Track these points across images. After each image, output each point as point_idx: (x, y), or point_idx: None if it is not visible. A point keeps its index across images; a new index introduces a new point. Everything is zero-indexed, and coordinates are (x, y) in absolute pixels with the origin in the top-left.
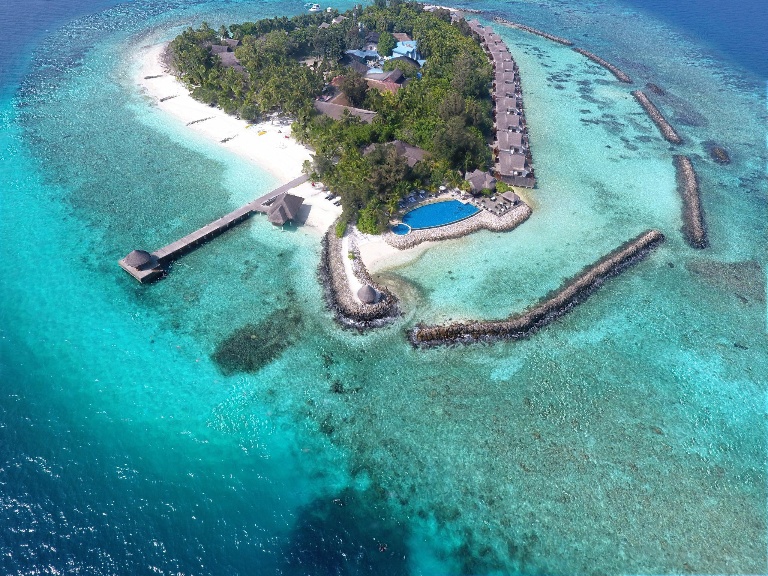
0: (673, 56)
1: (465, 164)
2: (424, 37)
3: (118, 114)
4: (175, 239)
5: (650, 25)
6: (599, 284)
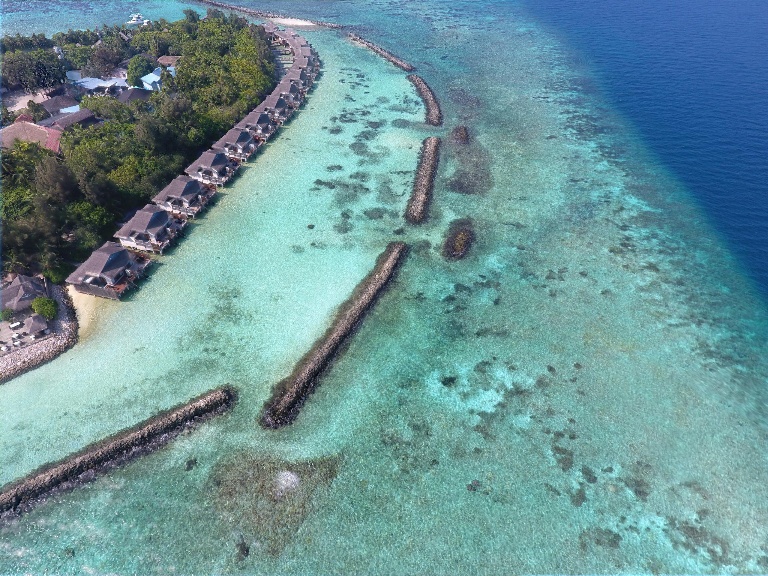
0: (530, 87)
1: (12, 266)
2: (179, 63)
3: None
4: None
5: (538, 45)
6: (22, 509)
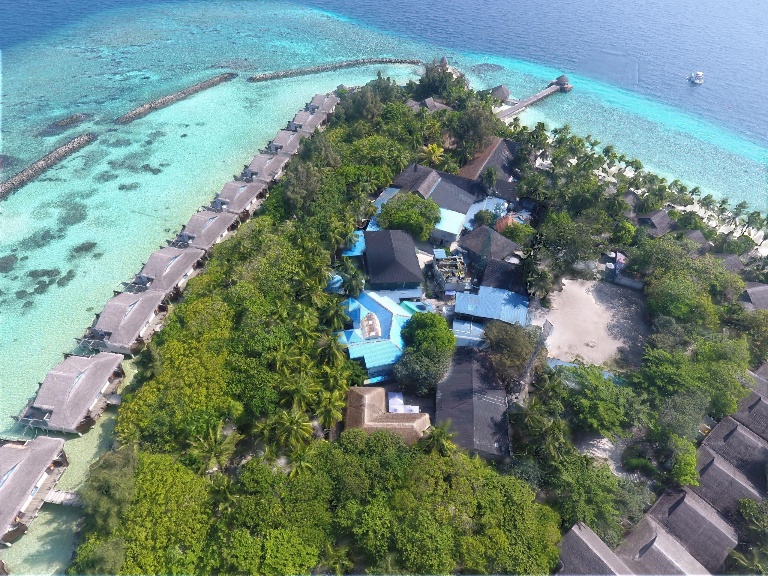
0: None
1: None
2: None
3: (748, 199)
4: (558, 99)
5: None
6: None
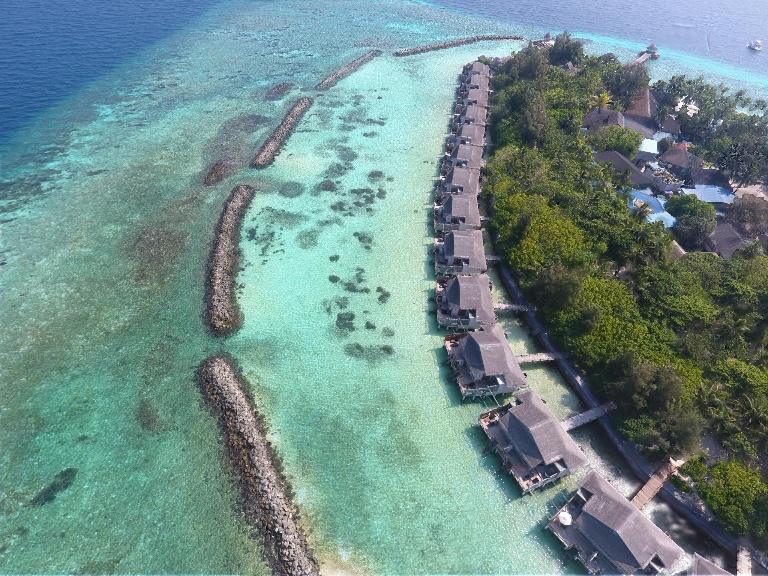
0: None
1: None
2: None
3: None
4: (652, 64)
5: None
6: None
